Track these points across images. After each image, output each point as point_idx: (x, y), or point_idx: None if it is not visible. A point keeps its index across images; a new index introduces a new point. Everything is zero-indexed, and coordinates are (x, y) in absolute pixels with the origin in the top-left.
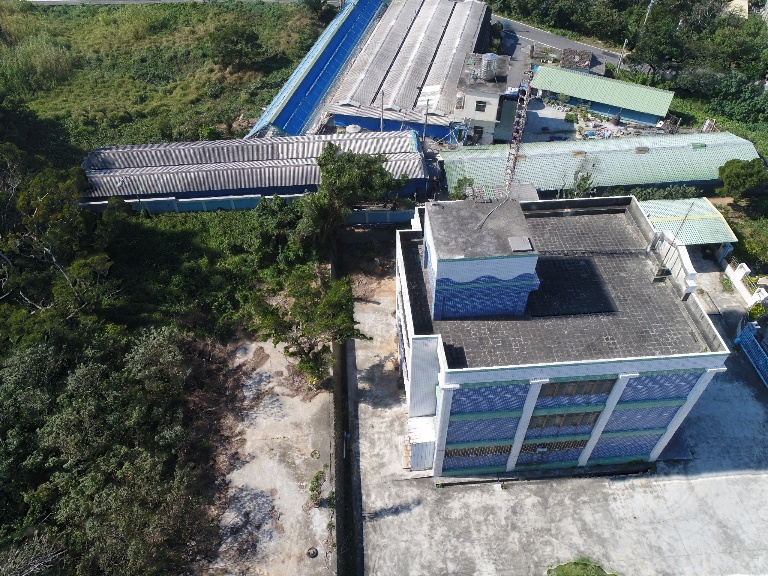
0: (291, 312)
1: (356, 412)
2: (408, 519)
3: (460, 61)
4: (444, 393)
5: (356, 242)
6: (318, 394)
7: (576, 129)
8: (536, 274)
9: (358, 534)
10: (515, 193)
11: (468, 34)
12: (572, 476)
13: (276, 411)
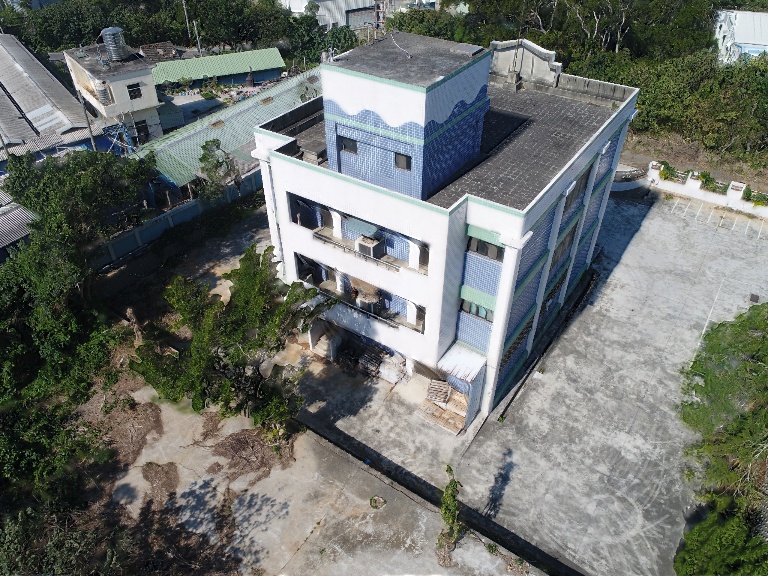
0: (205, 343)
1: (342, 434)
2: (521, 472)
3: (44, 80)
4: (517, 257)
5: (117, 291)
6: (293, 445)
7: (224, 101)
8: None
9: (505, 536)
10: (249, 153)
11: (23, 59)
12: (565, 320)
13: (268, 508)
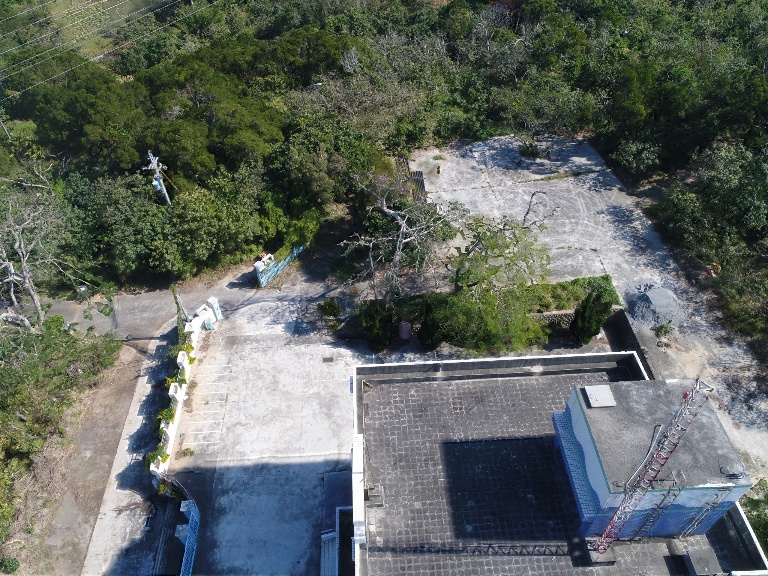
0: None
1: None
2: None
3: None
4: None
5: None
6: None
7: None
8: (559, 425)
9: None
10: None
11: None
12: None
13: None
